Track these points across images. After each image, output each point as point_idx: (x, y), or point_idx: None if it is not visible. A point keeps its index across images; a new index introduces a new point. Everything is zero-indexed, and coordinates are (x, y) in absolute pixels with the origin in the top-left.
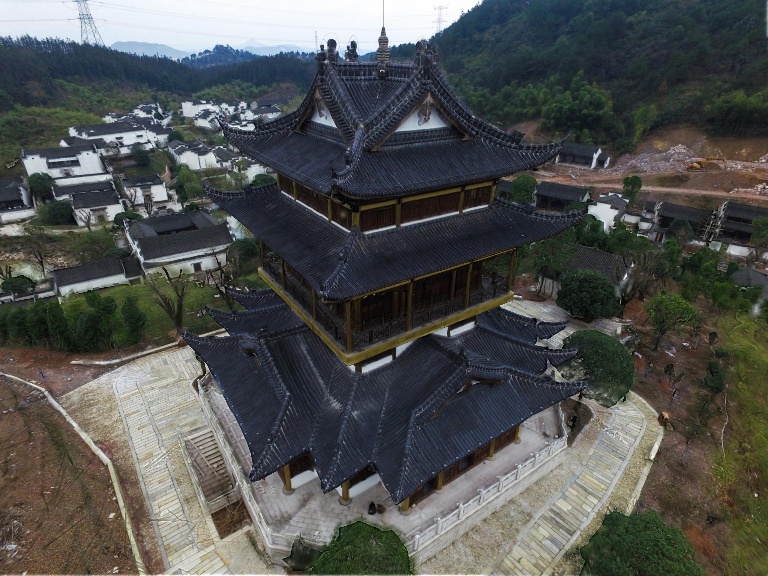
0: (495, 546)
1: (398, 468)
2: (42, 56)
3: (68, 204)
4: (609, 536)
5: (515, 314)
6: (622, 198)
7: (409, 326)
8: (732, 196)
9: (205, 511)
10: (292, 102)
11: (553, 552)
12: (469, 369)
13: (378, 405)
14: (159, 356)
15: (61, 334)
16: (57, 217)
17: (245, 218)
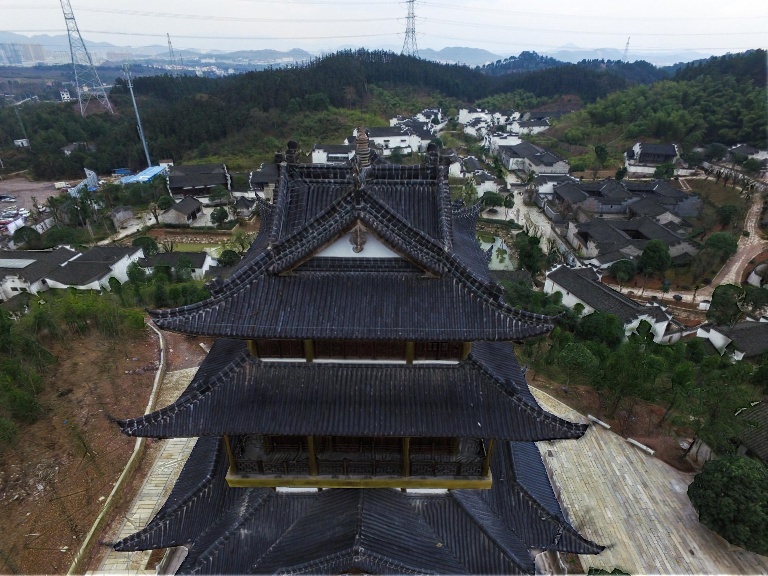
0: None
1: None
2: (367, 65)
3: None
4: None
5: (532, 497)
6: None
7: (314, 471)
8: None
9: None
10: (564, 117)
11: None
12: (358, 557)
13: (274, 535)
14: None
15: None
16: None
17: None
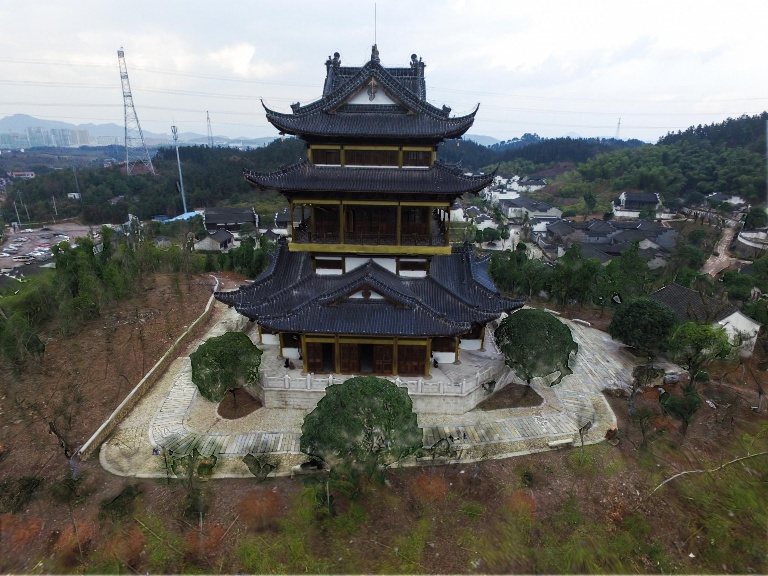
0: None
1: None
2: None
3: None
4: None
5: (483, 285)
6: None
7: (342, 240)
8: None
9: None
10: (559, 177)
11: None
12: (368, 279)
13: (314, 295)
14: None
15: (247, 263)
16: None
17: None
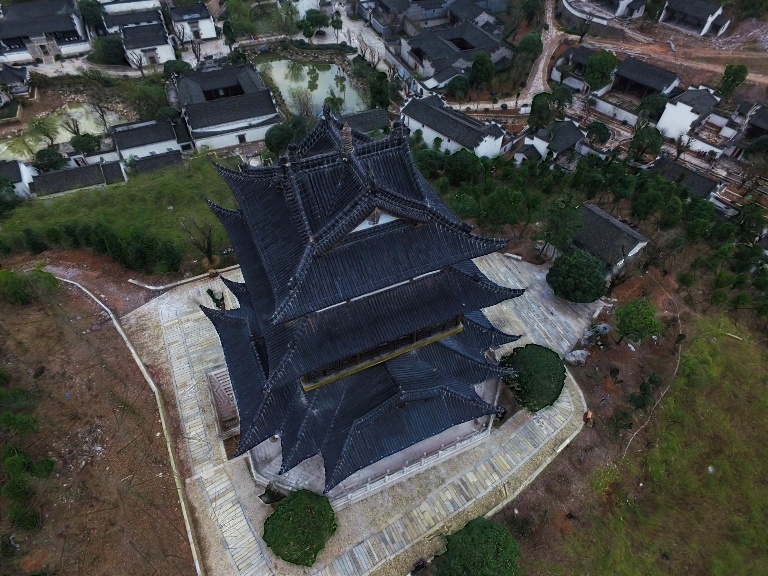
0: (410, 499)
1: (336, 462)
2: None
3: (119, 42)
4: (462, 539)
5: (476, 322)
6: (713, 95)
7: (359, 362)
8: None
9: (219, 438)
10: None
11: (449, 511)
12: (403, 396)
13: (334, 405)
14: (194, 286)
15: (118, 257)
16: (111, 56)
17: (238, 245)
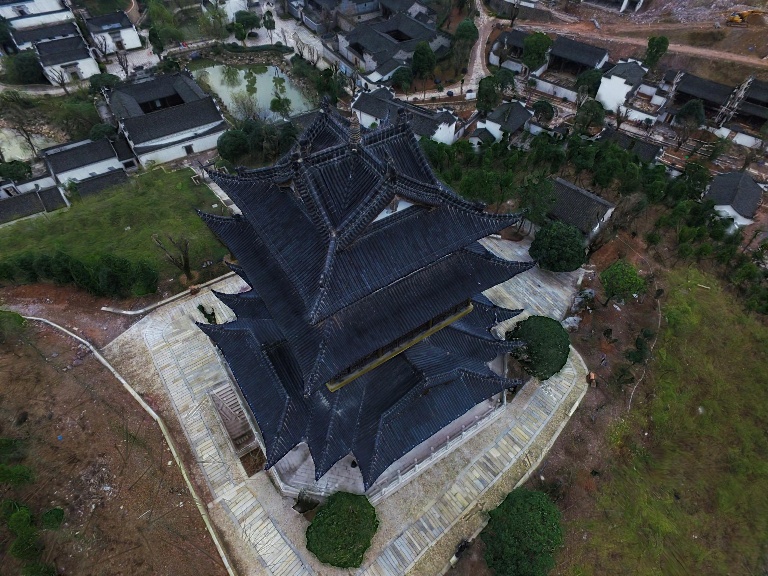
0: (440, 484)
1: (369, 458)
2: None
3: (35, 59)
4: (507, 511)
5: (478, 302)
6: (641, 66)
7: (380, 355)
8: (764, 65)
9: (235, 457)
10: None
11: (480, 489)
12: (427, 383)
13: (357, 402)
14: (176, 305)
15: (87, 285)
16: (27, 75)
17: (238, 253)
